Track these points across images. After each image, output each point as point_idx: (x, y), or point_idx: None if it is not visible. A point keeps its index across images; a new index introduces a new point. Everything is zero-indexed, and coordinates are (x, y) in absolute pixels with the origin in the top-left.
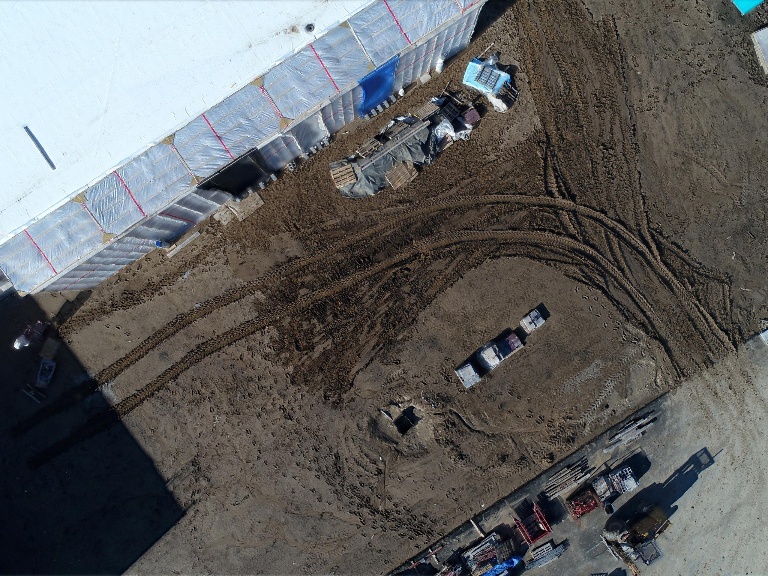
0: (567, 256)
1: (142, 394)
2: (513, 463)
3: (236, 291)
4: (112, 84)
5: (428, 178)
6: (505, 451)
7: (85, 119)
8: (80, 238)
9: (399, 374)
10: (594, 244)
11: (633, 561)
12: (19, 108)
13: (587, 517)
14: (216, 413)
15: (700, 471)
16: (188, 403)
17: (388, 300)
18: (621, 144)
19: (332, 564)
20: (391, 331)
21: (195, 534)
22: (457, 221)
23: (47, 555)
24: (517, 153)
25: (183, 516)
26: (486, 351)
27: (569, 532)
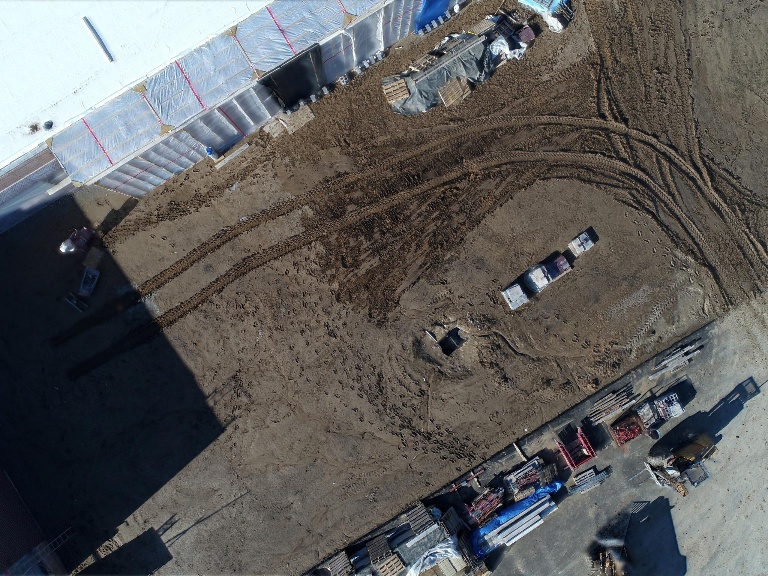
0: (618, 180)
1: (185, 307)
2: (558, 387)
3: (284, 205)
4: None
5: (480, 97)
6: (550, 375)
7: (144, 11)
8: (137, 129)
9: (445, 294)
10: (645, 169)
11: None
12: None
13: (631, 444)
14: (260, 328)
15: (746, 401)
16: (232, 317)
17: (436, 219)
18: (675, 69)
19: (372, 485)
20: (438, 251)
21: (235, 451)
22: (508, 141)
23: (84, 468)
24: (570, 74)
25: (223, 432)
26: (535, 272)
27: (612, 459)
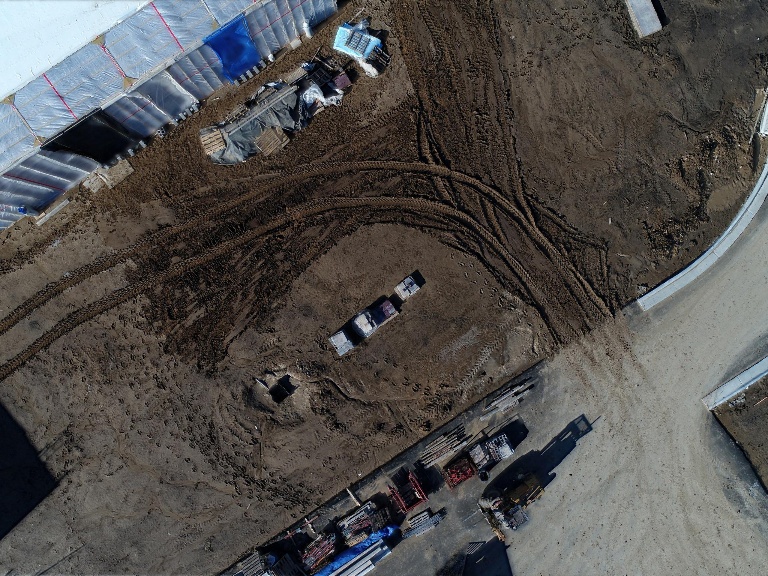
0: (442, 222)
1: (13, 364)
2: (389, 431)
3: (107, 259)
4: None
5: (300, 144)
6: (382, 419)
7: None
8: None
9: (274, 342)
10: (469, 210)
11: (506, 528)
12: None
13: (464, 485)
14: (88, 383)
15: (578, 438)
16: (60, 373)
17: (261, 268)
18: (495, 109)
19: (208, 534)
20: (265, 299)
21: (69, 505)
22: (330, 188)
23: None
24: (390, 119)
25: (56, 487)
26: (358, 318)
27: (446, 500)
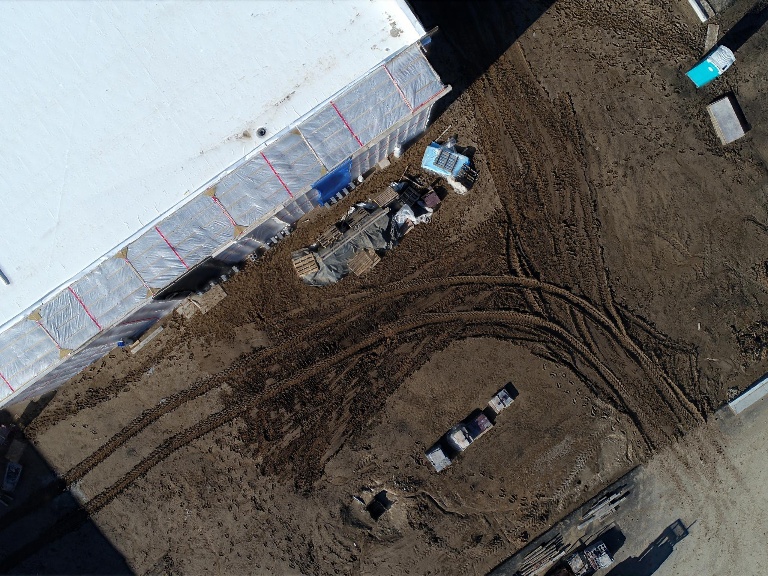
0: (533, 334)
1: (111, 492)
2: (488, 543)
3: (202, 384)
4: (63, 196)
5: (391, 262)
6: (479, 532)
7: (37, 232)
8: (36, 355)
9: (370, 459)
10: (560, 321)
11: None
12: None
13: None
14: (187, 507)
15: (675, 543)
16: (158, 499)
17: (356, 386)
18: (582, 220)
19: None
20: (360, 416)
21: None
22: (422, 304)
23: None
24: (479, 234)
25: None
26: (455, 434)
27: None
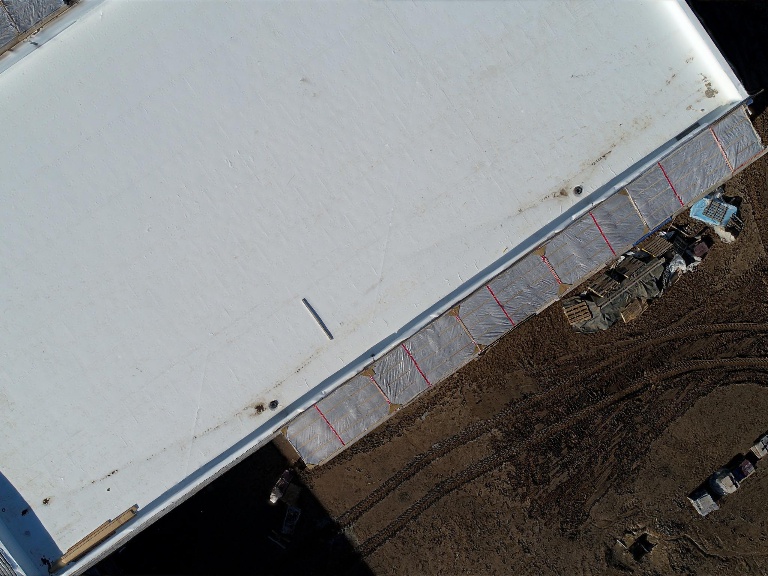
0: None
1: (383, 534)
2: None
3: (473, 429)
4: (387, 253)
5: (657, 310)
6: (740, 574)
7: (361, 289)
8: (367, 410)
9: (633, 503)
10: None
11: None
12: (296, 281)
13: None
14: (457, 550)
15: None
16: (429, 541)
17: (621, 431)
18: None
19: None
20: (624, 461)
21: None
22: (686, 351)
23: None
24: (743, 282)
25: None
26: (723, 480)
27: None
